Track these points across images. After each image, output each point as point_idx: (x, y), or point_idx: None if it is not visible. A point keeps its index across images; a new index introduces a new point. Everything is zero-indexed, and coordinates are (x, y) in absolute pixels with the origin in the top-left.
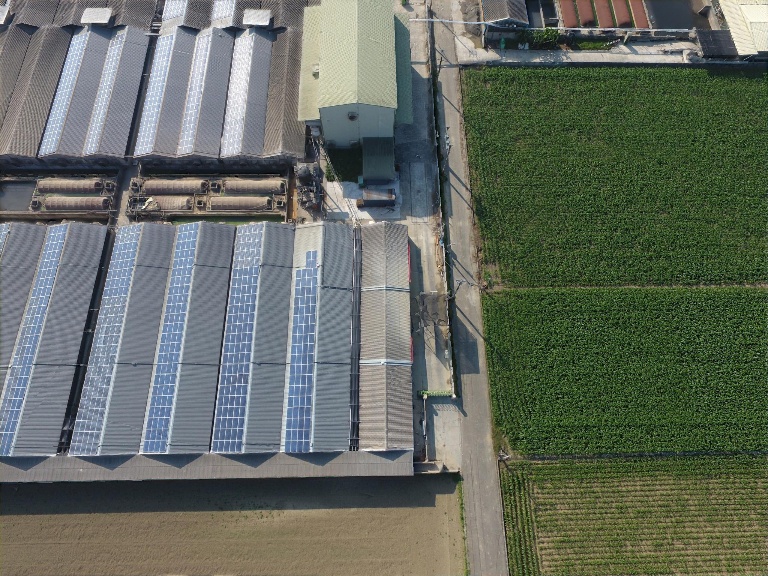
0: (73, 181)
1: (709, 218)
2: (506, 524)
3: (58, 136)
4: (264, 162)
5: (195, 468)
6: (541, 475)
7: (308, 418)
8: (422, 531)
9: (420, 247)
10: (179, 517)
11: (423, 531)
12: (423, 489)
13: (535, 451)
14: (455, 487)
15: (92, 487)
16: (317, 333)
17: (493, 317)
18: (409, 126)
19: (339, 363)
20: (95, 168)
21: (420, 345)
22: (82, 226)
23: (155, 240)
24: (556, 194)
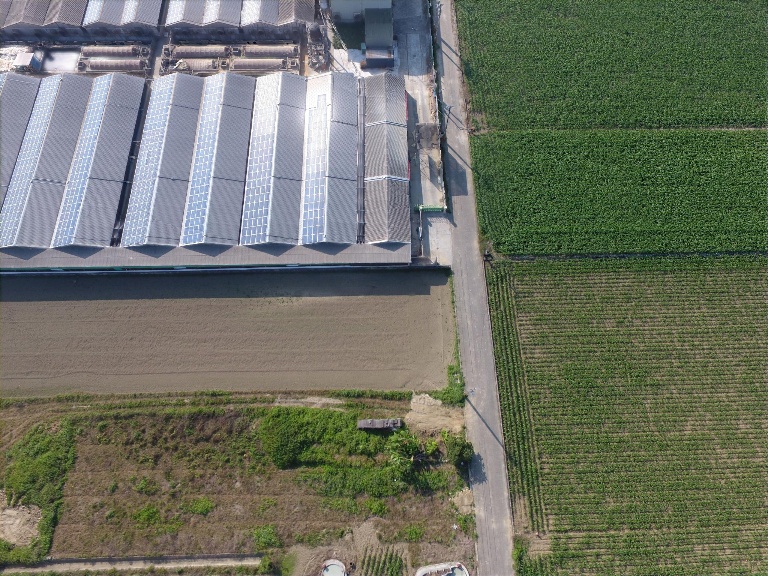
0: (113, 47)
1: (670, 76)
2: (490, 306)
3: (100, 8)
4: (279, 31)
5: (227, 257)
6: (520, 270)
7: (321, 217)
8: (419, 312)
9: (416, 99)
10: (213, 302)
11: (420, 312)
12: (420, 282)
13: (515, 252)
14: (447, 280)
15: (139, 280)
16: (328, 155)
17: (479, 152)
18: (406, 5)
19: (347, 179)
20: (131, 40)
21: (416, 173)
22: (124, 76)
23: (187, 87)
24: (535, 58)
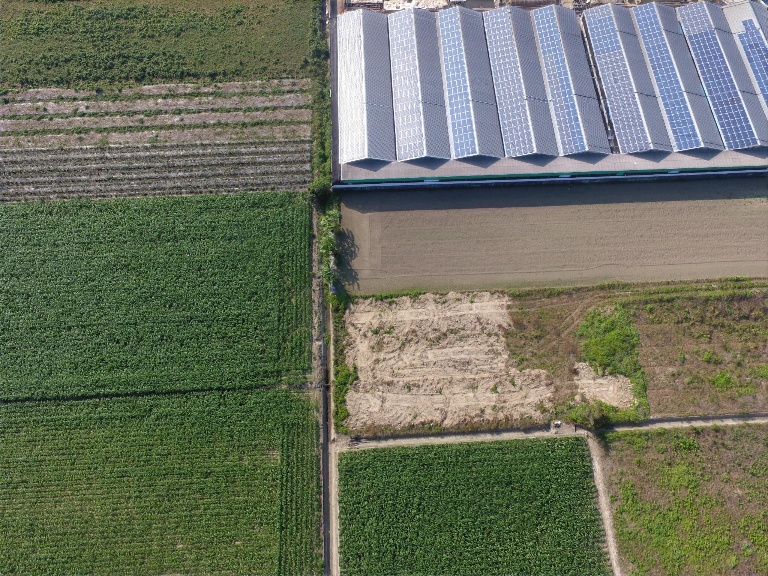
0: None
1: None
2: None
3: None
4: None
5: (719, 160)
6: None
7: None
8: None
9: None
10: (700, 203)
11: None
12: None
13: None
14: None
15: (626, 186)
16: None
17: None
18: None
19: None
20: None
21: None
22: (561, 8)
23: (621, 16)
24: None
